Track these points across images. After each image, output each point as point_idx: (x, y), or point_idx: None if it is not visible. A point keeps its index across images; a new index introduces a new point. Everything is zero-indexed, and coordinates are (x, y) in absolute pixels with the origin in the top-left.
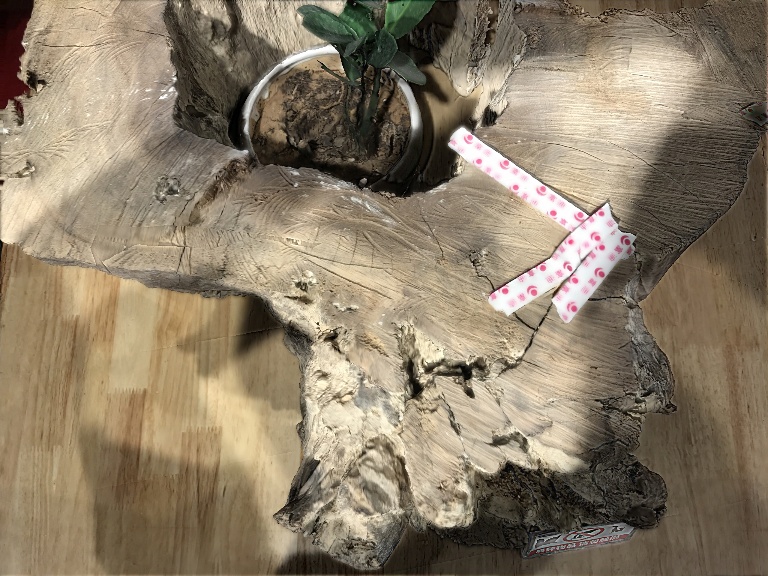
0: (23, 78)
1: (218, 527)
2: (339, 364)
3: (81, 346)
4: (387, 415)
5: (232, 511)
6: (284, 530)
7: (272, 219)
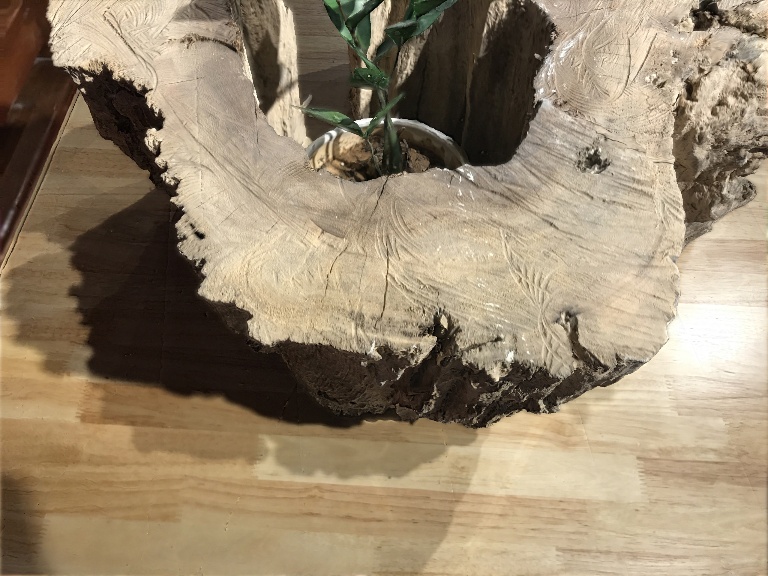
0: (429, 342)
1: (766, 378)
2: (721, 73)
3: (596, 541)
4: (761, 38)
5: (747, 365)
6: (752, 318)
7: (595, 105)
